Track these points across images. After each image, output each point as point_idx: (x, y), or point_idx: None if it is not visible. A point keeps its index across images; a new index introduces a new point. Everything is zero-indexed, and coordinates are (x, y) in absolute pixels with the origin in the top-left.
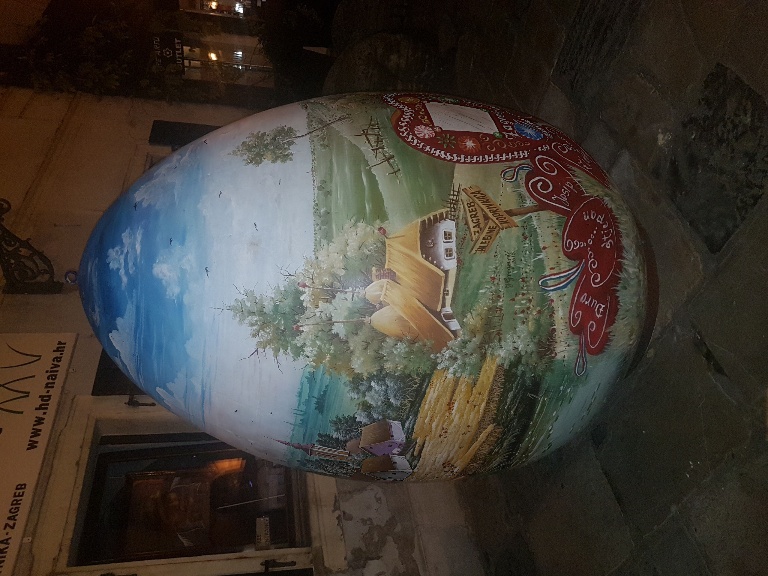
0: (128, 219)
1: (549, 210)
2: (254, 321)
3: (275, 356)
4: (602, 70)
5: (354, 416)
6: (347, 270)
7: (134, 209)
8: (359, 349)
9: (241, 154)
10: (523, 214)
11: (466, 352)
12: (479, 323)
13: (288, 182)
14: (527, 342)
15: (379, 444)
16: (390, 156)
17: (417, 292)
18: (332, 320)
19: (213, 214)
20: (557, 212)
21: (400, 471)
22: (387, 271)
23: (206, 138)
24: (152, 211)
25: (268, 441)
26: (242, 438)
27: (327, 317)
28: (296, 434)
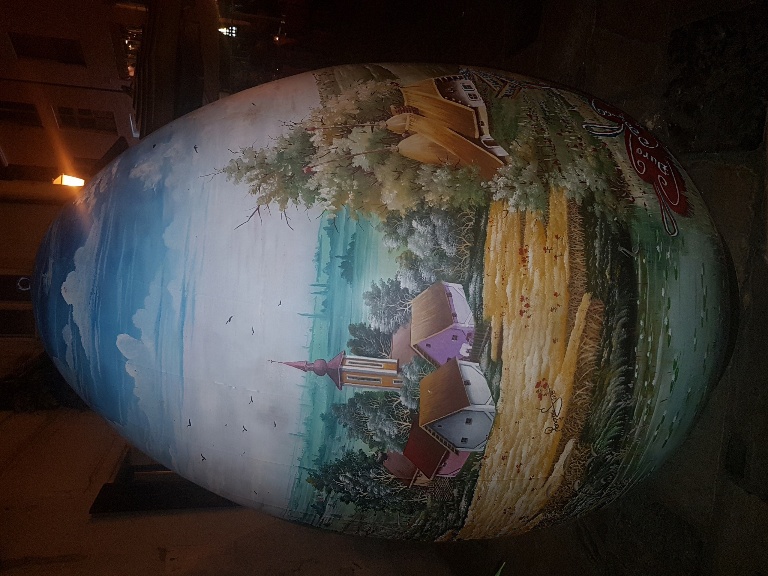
0: None
1: (567, 91)
2: (254, 176)
3: (282, 209)
4: None
5: (396, 280)
6: (361, 109)
7: None
8: (389, 180)
9: None
10: (541, 86)
11: (523, 180)
12: (529, 151)
13: (286, 81)
14: (593, 178)
15: (438, 335)
16: None
17: (447, 122)
18: (351, 154)
19: (204, 114)
20: (576, 94)
21: (477, 411)
22: (408, 107)
23: None
24: (134, 146)
25: (277, 373)
26: (238, 391)
27: (344, 152)
28: (317, 337)
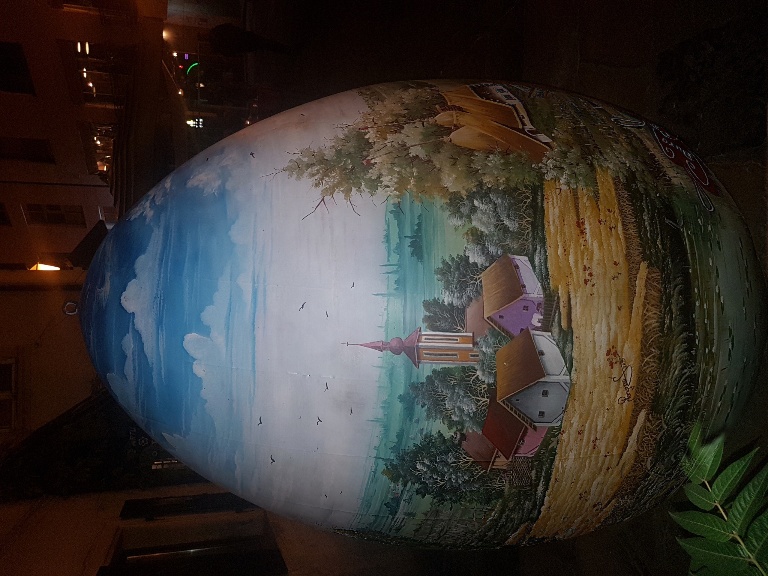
0: None
1: None
2: (315, 171)
3: (347, 198)
4: None
5: (465, 255)
6: (409, 110)
7: None
8: (447, 166)
9: None
10: None
11: (570, 162)
12: (570, 138)
13: None
14: (631, 160)
15: (510, 307)
16: None
17: (491, 117)
18: (407, 146)
19: (253, 129)
20: None
21: (552, 382)
22: (452, 106)
23: None
24: (183, 165)
25: (353, 356)
26: (312, 379)
27: (400, 144)
28: (392, 316)
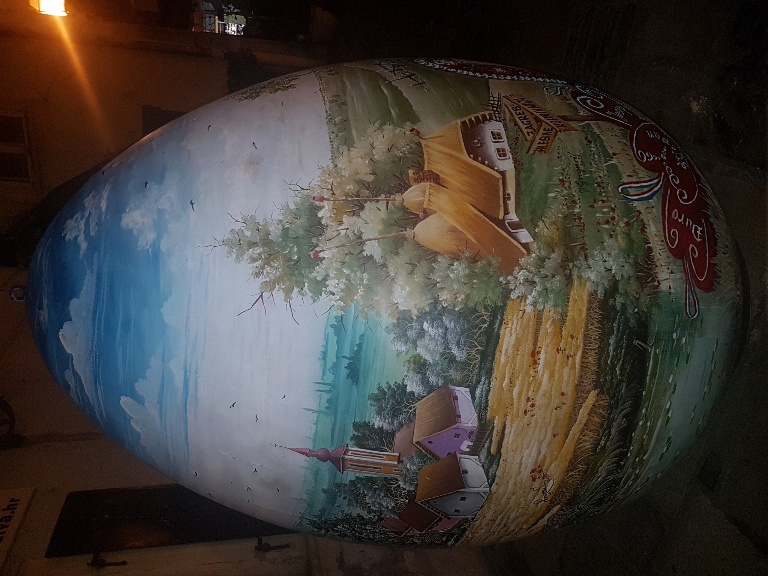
0: (93, 185)
1: (607, 121)
2: (256, 255)
3: (287, 300)
4: (606, 82)
5: (403, 383)
6: (376, 175)
7: (101, 174)
8: (402, 274)
9: (233, 97)
10: (580, 121)
11: (545, 273)
12: (556, 234)
13: (292, 102)
14: (620, 262)
15: (441, 434)
16: (411, 74)
17: (470, 196)
18: (362, 238)
19: (200, 146)
20: (617, 124)
21: (472, 492)
22: (428, 173)
23: None
24: (124, 166)
25: (280, 455)
26: (242, 462)
27: (355, 235)
28: (321, 430)
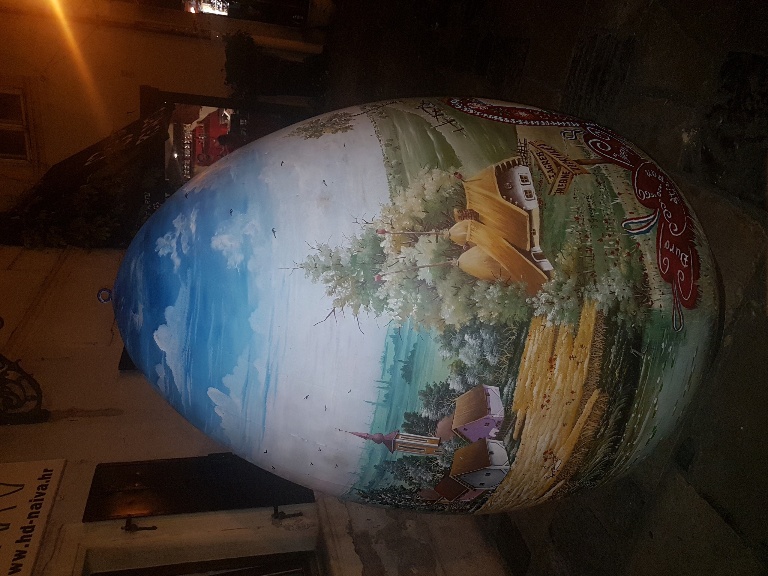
0: (179, 207)
1: (614, 164)
2: (330, 276)
3: (355, 314)
4: (608, 105)
5: (447, 382)
6: (428, 213)
7: (185, 198)
8: (449, 296)
9: (298, 134)
10: (591, 164)
11: (562, 295)
12: (571, 263)
13: (353, 144)
14: (622, 286)
15: (474, 423)
16: (451, 120)
17: (503, 232)
18: (417, 265)
19: (276, 180)
20: (622, 166)
21: (495, 469)
22: (469, 212)
23: None
24: (207, 193)
25: (343, 437)
26: (309, 442)
27: (411, 262)
28: (378, 418)
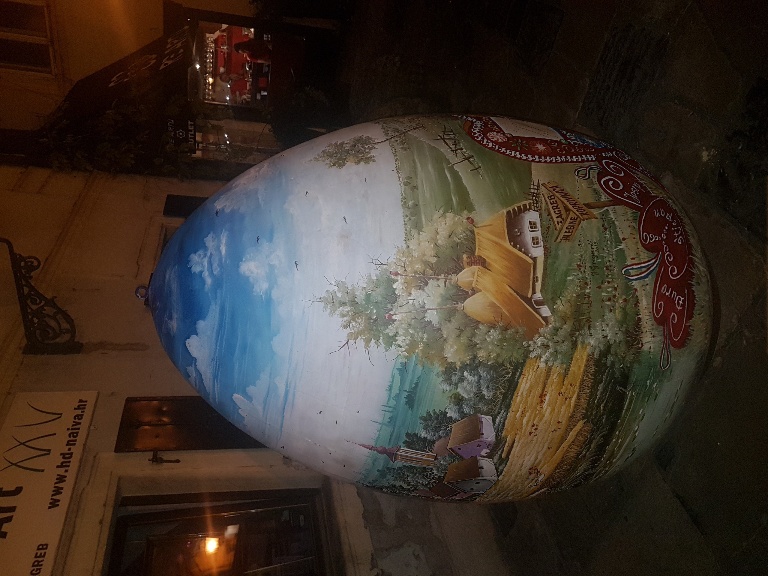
0: (210, 225)
1: (623, 205)
2: (345, 312)
3: (366, 347)
4: (636, 104)
5: (445, 411)
6: (439, 257)
7: (216, 215)
8: (452, 337)
9: (323, 159)
10: (600, 207)
11: (557, 339)
12: (569, 310)
13: (374, 180)
14: (615, 331)
15: (468, 444)
16: (469, 156)
17: (508, 278)
18: (425, 307)
19: (301, 211)
20: (630, 207)
21: (485, 479)
22: (478, 258)
23: (281, 153)
24: (236, 215)
25: (350, 447)
26: (321, 447)
27: (420, 304)
28: (382, 435)
